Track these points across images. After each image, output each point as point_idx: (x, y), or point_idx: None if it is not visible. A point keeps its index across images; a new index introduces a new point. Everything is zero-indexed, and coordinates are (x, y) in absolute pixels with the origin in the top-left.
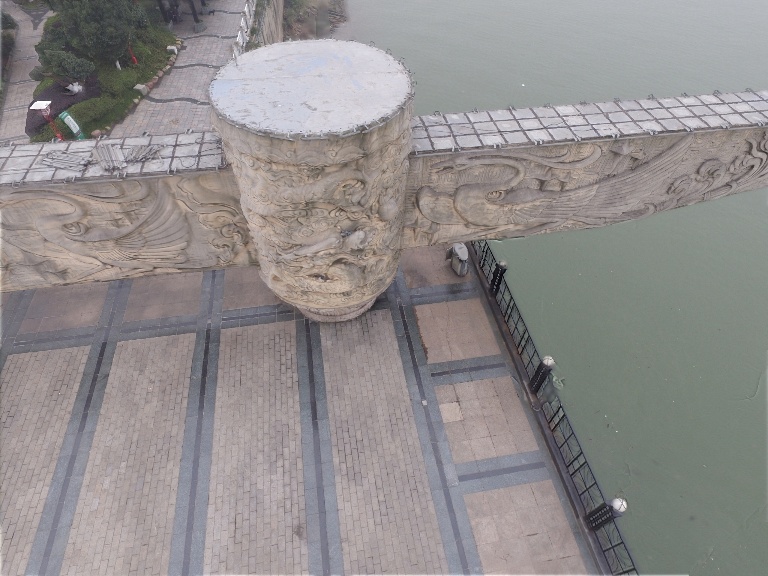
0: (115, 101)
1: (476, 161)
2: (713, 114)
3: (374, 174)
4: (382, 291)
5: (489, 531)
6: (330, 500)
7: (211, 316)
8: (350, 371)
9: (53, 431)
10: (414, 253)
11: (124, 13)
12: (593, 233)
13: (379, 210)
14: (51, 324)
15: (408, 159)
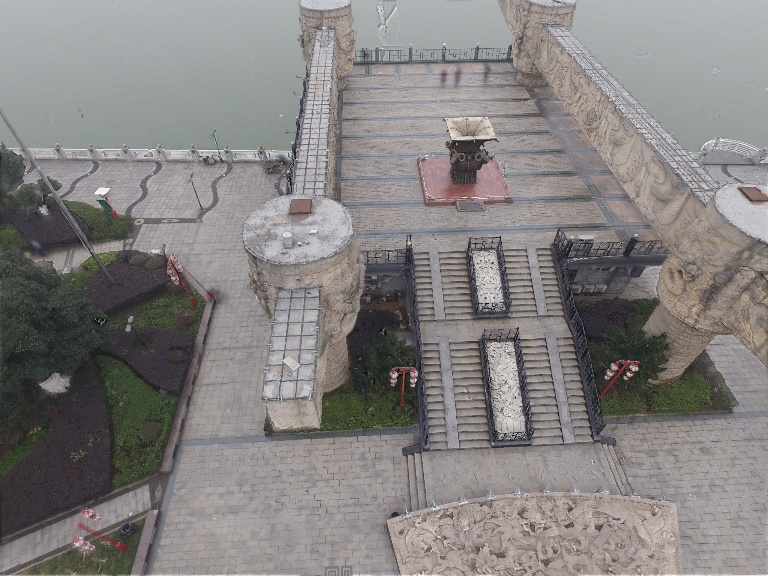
0: None
1: None
2: None
3: None
4: None
5: None
6: None
7: None
8: None
9: None
10: None
11: None
12: None
13: None
14: None
15: None
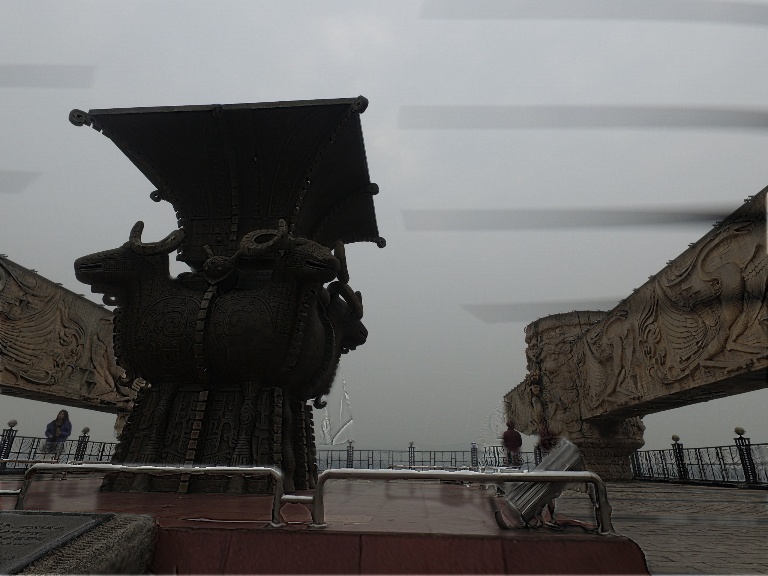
0: None
1: None
2: None
3: None
4: None
5: None
6: None
7: None
8: None
9: None
10: None
11: None
12: None
13: None
14: None
15: None
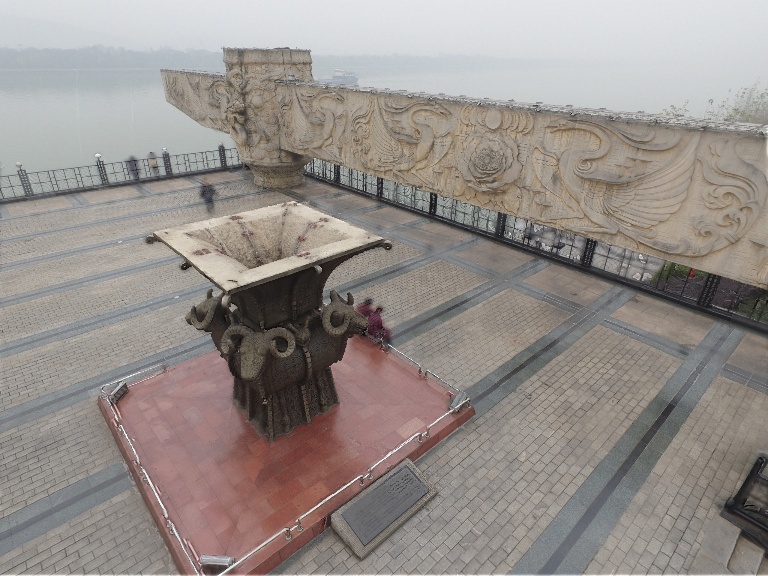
0: None
1: None
2: None
3: None
4: None
5: None
6: (9, 238)
7: None
8: None
9: None
10: None
11: None
12: None
13: None
14: None
15: None
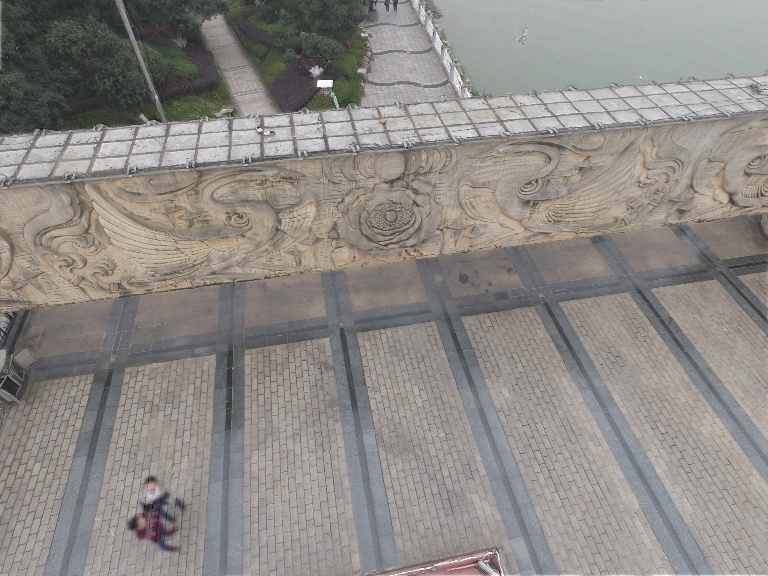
0: (351, 84)
1: None
2: None
3: None
4: None
5: None
6: None
7: (716, 265)
8: None
9: (671, 369)
10: None
11: None
12: None
13: None
14: (571, 274)
15: None
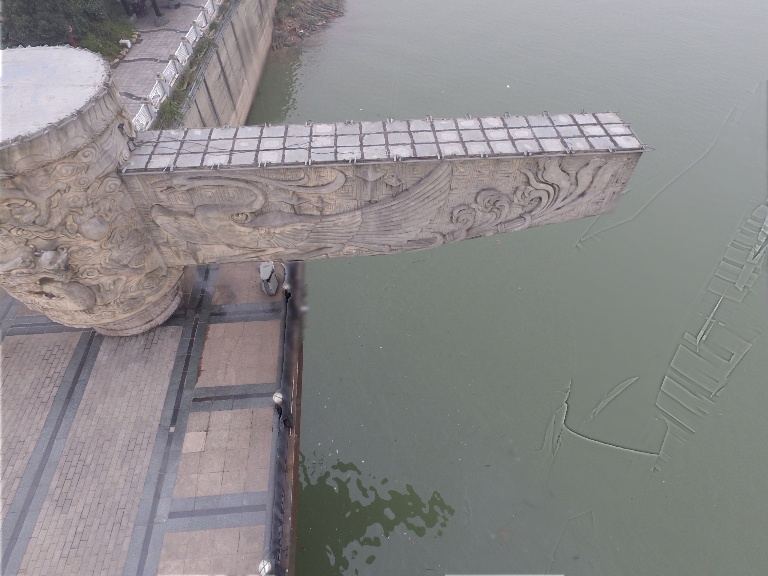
0: None
1: (198, 182)
2: (482, 140)
3: (44, 194)
4: (147, 309)
5: (173, 575)
6: (28, 526)
7: (2, 322)
8: (112, 389)
9: None
10: (235, 267)
11: (60, 6)
12: (385, 260)
13: (78, 230)
14: None
15: (118, 177)
